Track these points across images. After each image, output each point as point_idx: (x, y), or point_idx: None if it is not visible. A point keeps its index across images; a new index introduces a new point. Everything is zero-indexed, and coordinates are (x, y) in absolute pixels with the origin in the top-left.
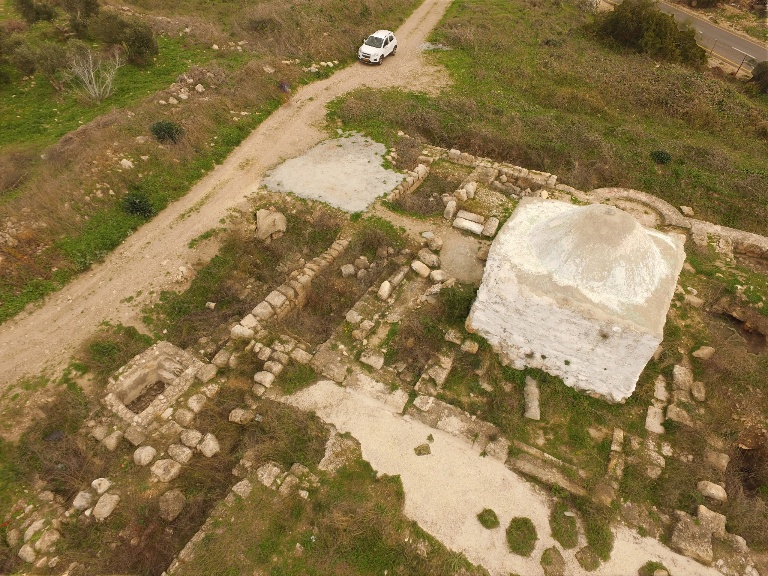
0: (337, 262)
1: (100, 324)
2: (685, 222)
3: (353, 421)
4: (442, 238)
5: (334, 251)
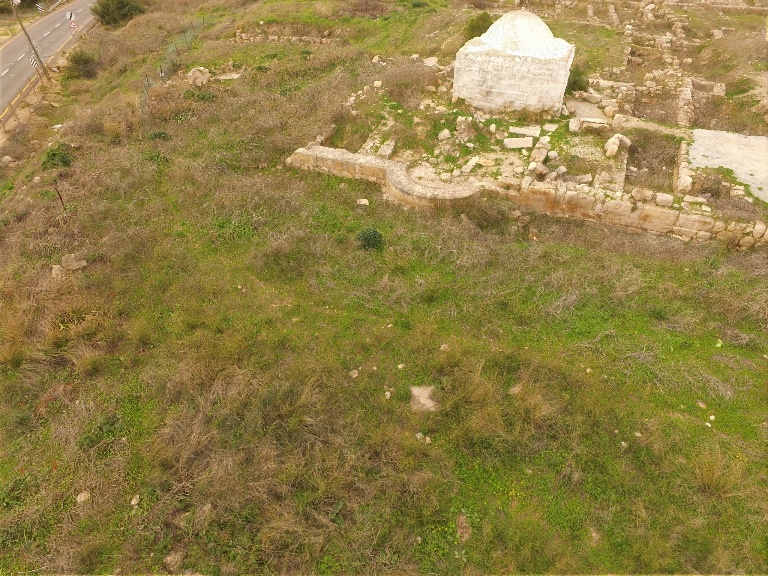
0: (672, 115)
1: (763, 86)
2: (389, 164)
3: (596, 81)
4: (608, 120)
5: (682, 117)
